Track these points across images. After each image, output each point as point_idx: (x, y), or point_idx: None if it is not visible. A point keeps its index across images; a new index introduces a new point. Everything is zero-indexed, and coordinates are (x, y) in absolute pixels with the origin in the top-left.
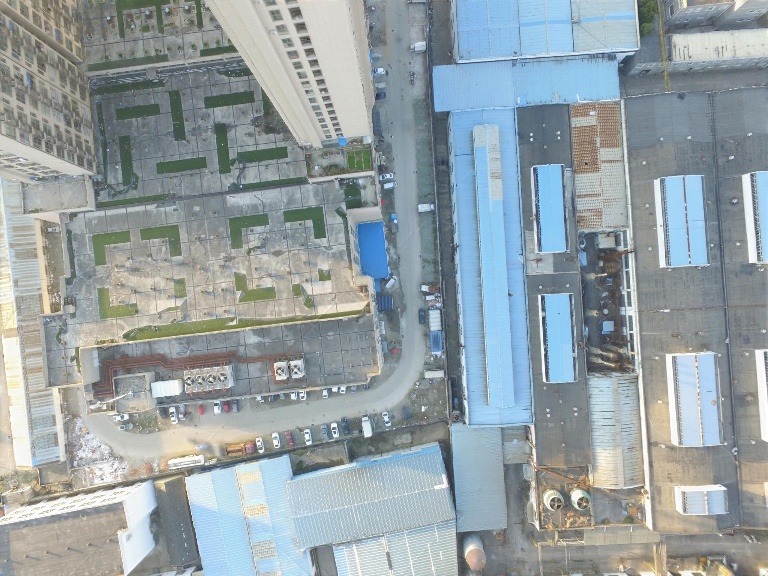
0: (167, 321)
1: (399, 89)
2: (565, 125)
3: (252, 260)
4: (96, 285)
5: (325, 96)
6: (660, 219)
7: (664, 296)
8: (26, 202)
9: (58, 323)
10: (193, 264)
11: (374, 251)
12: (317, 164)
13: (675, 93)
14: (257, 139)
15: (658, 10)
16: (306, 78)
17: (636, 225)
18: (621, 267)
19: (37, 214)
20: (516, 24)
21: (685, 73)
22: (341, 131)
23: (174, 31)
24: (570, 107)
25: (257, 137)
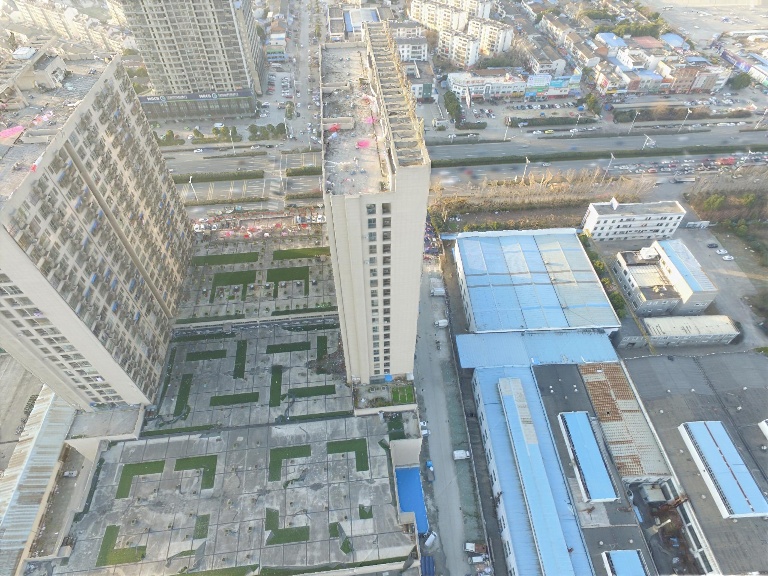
0: (176, 570)
1: (427, 353)
2: (578, 380)
3: (288, 494)
4: (107, 522)
5: (386, 325)
6: (700, 464)
7: (744, 554)
8: (73, 428)
9: (42, 572)
10: (223, 498)
11: (411, 500)
12: (364, 398)
13: (664, 356)
14: (309, 378)
15: (625, 302)
16: (377, 306)
17: (678, 472)
18: (681, 521)
19: (78, 440)
20: (518, 308)
21: (665, 347)
22: (389, 366)
23: (254, 299)
24: (578, 366)
25: (309, 376)
